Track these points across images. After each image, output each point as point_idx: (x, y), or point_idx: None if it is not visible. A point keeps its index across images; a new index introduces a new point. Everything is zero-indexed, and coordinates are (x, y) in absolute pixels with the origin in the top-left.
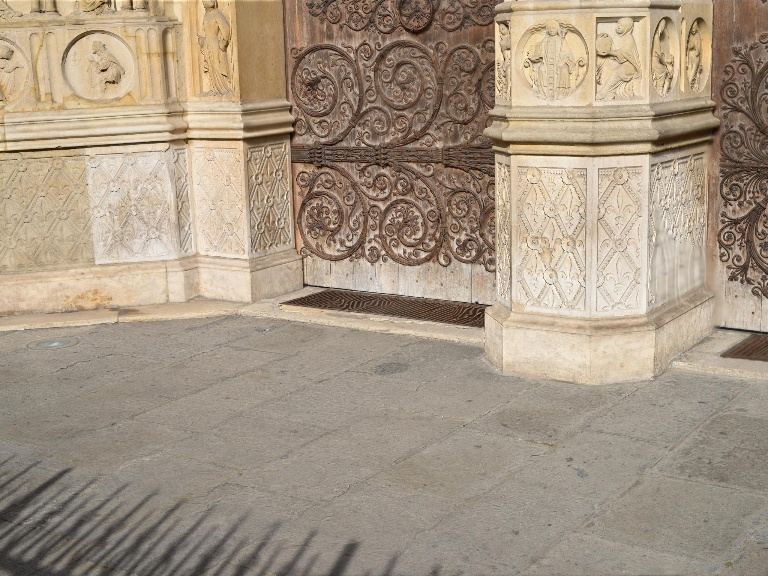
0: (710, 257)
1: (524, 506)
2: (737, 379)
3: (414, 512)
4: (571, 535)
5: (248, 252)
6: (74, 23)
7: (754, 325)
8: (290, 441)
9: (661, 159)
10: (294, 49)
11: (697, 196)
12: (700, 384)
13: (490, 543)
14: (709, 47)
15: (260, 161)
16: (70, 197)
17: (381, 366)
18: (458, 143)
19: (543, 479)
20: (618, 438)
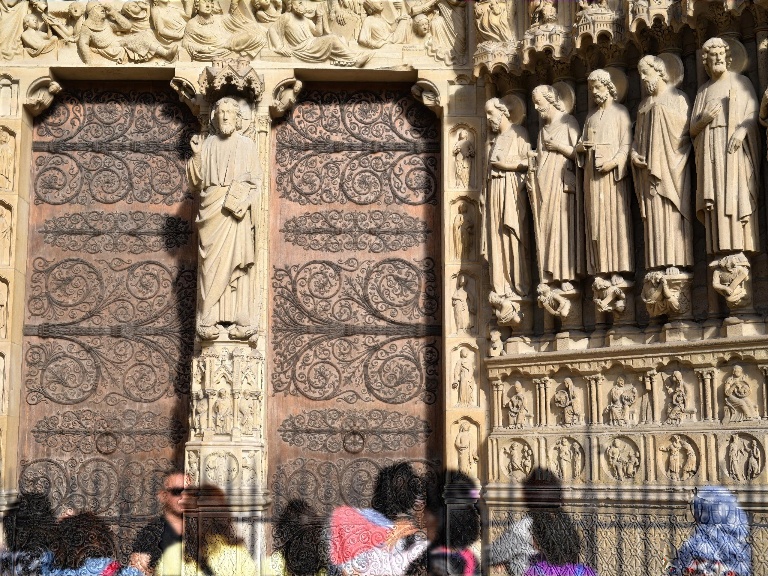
0: (267, 567)
1: None
2: None
3: None
4: None
5: None
6: None
7: None
8: None
9: None
10: (23, 461)
11: (265, 535)
12: None
13: None
14: (267, 465)
15: (7, 525)
16: None
17: None
18: (129, 513)
19: None
20: None
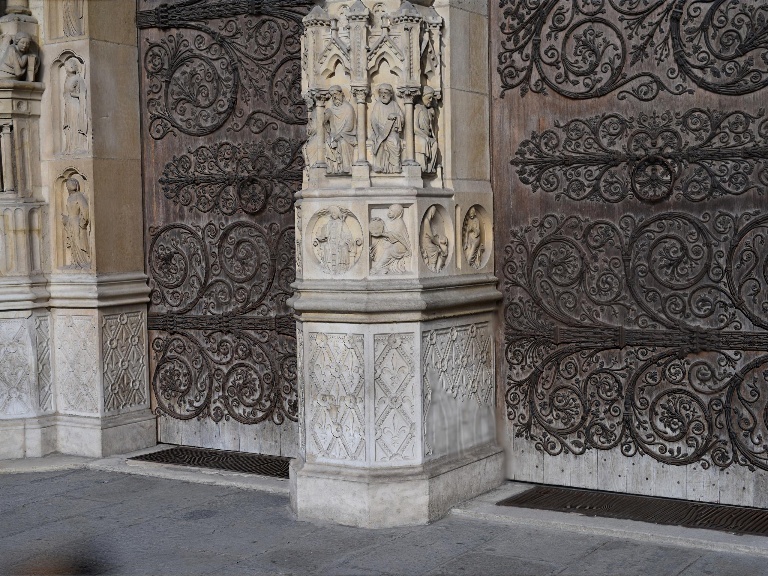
0: (500, 416)
1: None
2: (503, 524)
3: None
4: None
5: (101, 411)
6: None
7: (538, 478)
8: (76, 575)
9: (435, 326)
10: (152, 228)
11: (482, 360)
12: (467, 528)
13: None
14: (491, 230)
15: (115, 328)
16: None
17: (192, 513)
18: (289, 312)
19: None
20: (367, 572)
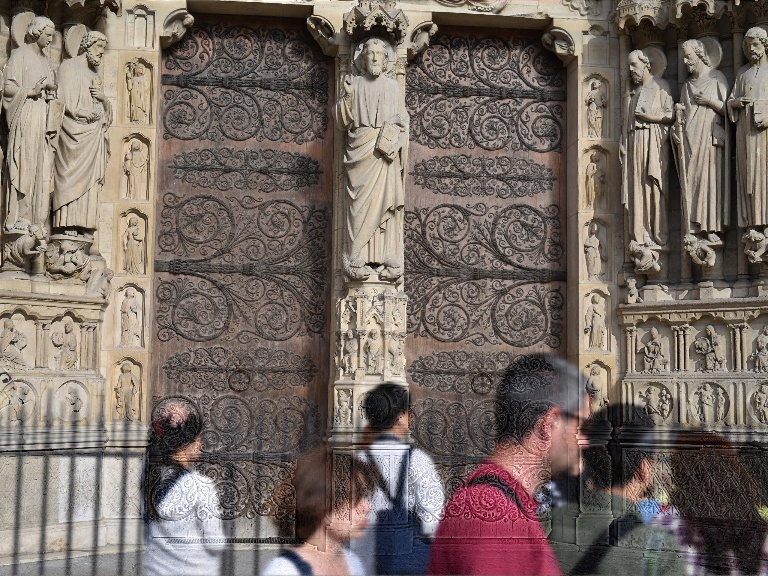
0: None
1: (459, 575)
2: None
3: None
4: None
5: (143, 514)
6: (61, 375)
7: (419, 535)
8: (328, 573)
9: None
10: (155, 397)
11: None
12: None
13: None
14: None
15: None
16: (50, 480)
17: None
18: (262, 450)
19: None
20: None
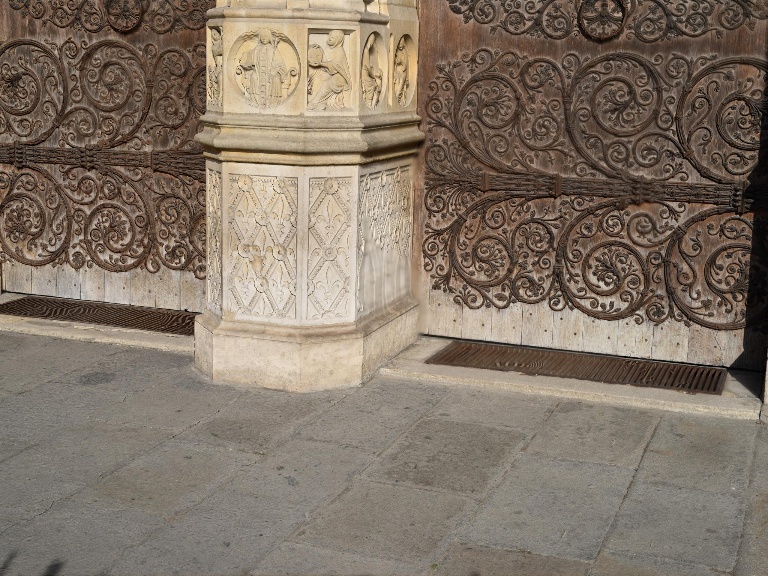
0: (415, 266)
1: (235, 517)
2: (440, 385)
3: (122, 528)
4: (282, 544)
5: None
6: None
7: (456, 332)
8: None
9: (370, 170)
10: None
11: (403, 207)
12: (406, 390)
13: (201, 556)
14: (415, 63)
15: None
16: None
17: (86, 376)
18: (168, 148)
19: (254, 489)
20: (328, 445)
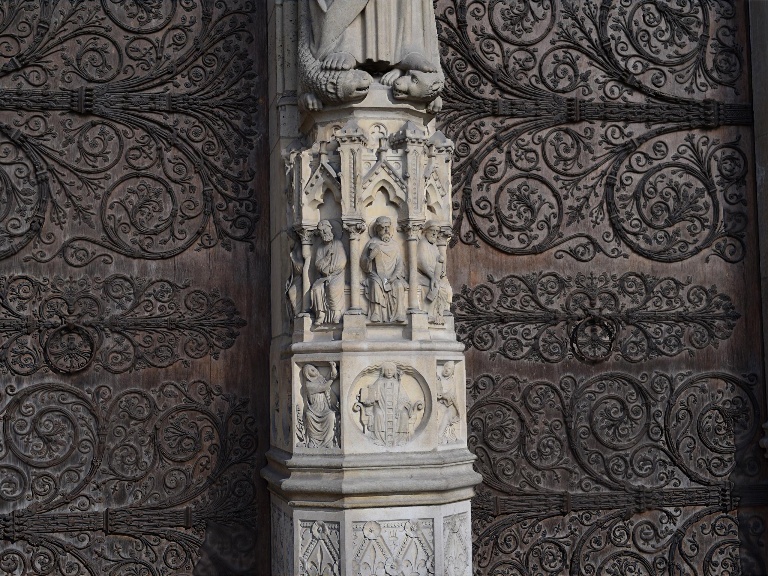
0: None
1: None
2: None
3: None
4: None
5: None
6: None
7: None
8: None
9: None
10: None
11: None
12: None
13: None
14: None
15: None
16: None
17: None
18: (125, 504)
19: None
20: None
